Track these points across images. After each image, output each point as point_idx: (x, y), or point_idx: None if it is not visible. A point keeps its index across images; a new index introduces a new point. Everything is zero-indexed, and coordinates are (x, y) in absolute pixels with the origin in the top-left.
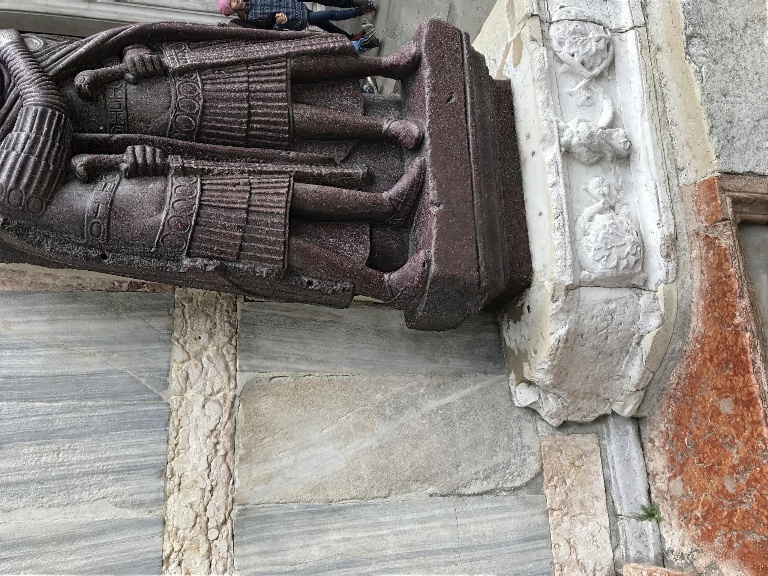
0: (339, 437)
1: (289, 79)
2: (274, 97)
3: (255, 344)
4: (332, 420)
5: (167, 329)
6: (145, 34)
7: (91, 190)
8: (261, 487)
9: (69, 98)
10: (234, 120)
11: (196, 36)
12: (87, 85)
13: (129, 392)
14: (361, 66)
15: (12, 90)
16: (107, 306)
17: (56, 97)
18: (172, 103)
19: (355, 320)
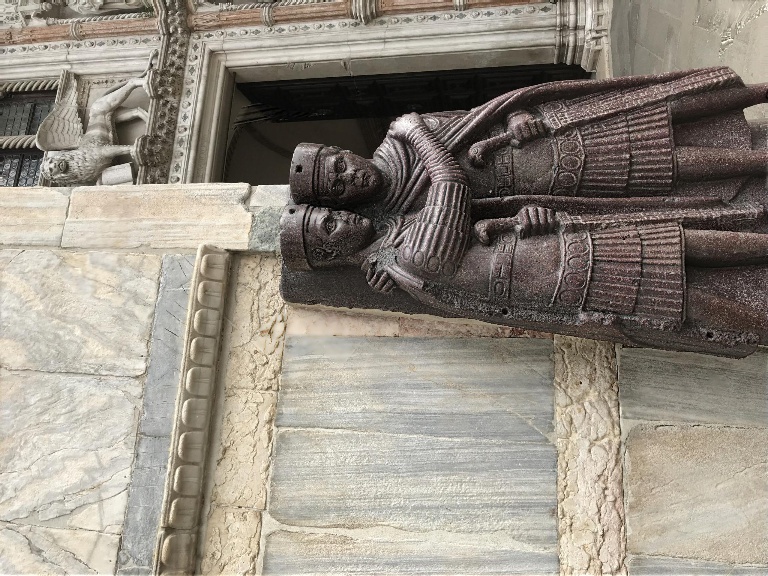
0: (737, 494)
1: (671, 123)
2: (657, 144)
3: (637, 391)
4: (728, 475)
5: (549, 374)
6: (525, 100)
7: (493, 252)
8: (654, 538)
9: (463, 168)
10: (615, 171)
11: (571, 93)
12: (480, 155)
13: (518, 432)
14: (748, 97)
15: (416, 166)
16: (493, 351)
17: (459, 171)
18: (555, 162)
19: (747, 368)
